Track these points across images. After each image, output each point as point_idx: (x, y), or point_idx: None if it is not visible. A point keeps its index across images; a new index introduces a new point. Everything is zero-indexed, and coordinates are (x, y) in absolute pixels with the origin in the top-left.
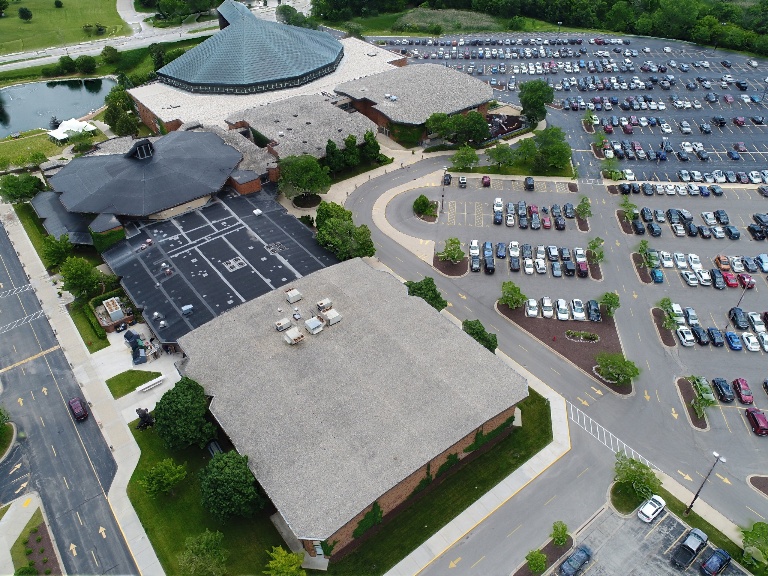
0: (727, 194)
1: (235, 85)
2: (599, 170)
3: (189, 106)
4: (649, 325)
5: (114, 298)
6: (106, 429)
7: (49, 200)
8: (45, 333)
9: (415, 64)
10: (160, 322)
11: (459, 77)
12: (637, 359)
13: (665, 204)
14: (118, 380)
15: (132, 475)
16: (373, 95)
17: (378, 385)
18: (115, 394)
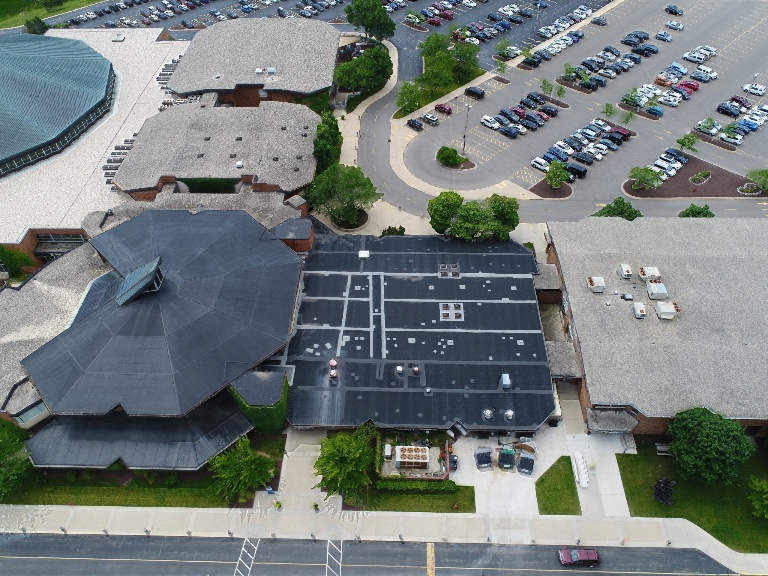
0: (584, 34)
1: (40, 146)
2: (490, 57)
3: (6, 206)
4: (705, 145)
5: (398, 446)
6: (628, 540)
7: (72, 439)
8: (388, 552)
9: (204, 29)
10: (508, 414)
11: (281, 23)
12: (740, 170)
13: (568, 60)
14: (549, 500)
15: (717, 539)
16: (240, 77)
17: (761, 291)
18: (572, 511)
